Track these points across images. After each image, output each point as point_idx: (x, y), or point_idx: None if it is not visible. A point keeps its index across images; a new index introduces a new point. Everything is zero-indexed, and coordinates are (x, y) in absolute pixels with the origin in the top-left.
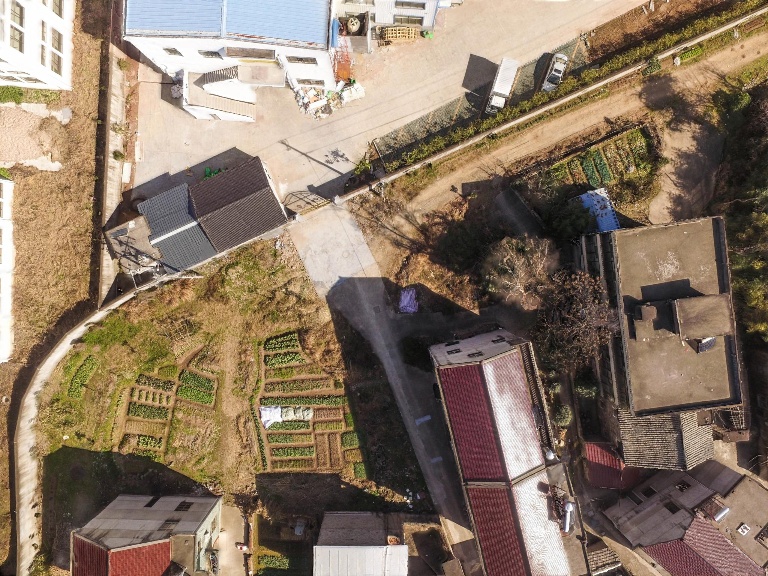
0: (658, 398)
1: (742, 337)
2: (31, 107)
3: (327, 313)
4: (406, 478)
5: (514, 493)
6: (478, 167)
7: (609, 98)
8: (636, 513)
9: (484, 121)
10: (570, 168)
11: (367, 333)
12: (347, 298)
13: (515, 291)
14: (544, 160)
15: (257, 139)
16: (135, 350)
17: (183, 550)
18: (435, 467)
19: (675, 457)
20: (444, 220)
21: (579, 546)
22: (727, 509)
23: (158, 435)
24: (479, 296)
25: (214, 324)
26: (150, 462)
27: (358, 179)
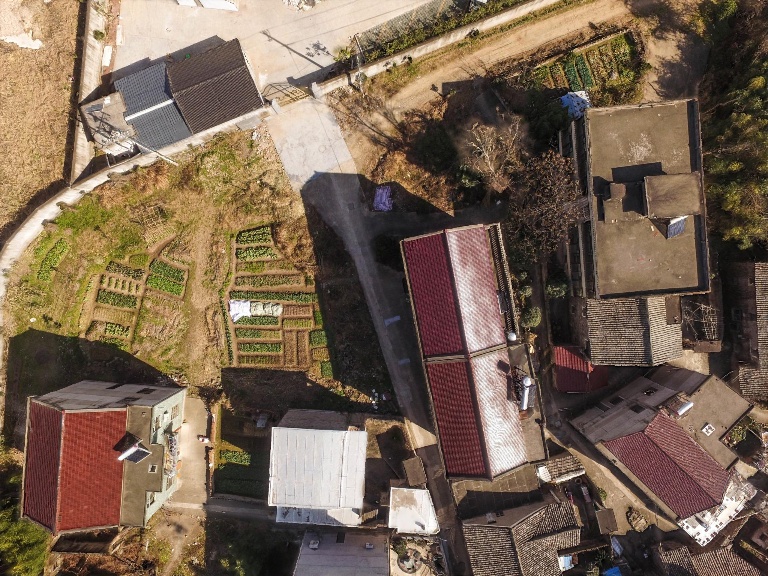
0: (625, 283)
1: (719, 251)
2: None
3: (301, 207)
4: (373, 379)
5: (473, 366)
6: (459, 67)
7: (594, 3)
8: (602, 418)
9: (466, 14)
10: (552, 72)
11: (340, 230)
12: (322, 193)
13: None
14: (525, 59)
15: (239, 28)
16: (107, 235)
17: (140, 422)
18: (402, 369)
19: (642, 353)
20: (423, 119)
21: (538, 430)
22: (691, 403)
23: (126, 323)
24: (454, 197)
25: (187, 214)
26: (116, 350)
27: (338, 73)
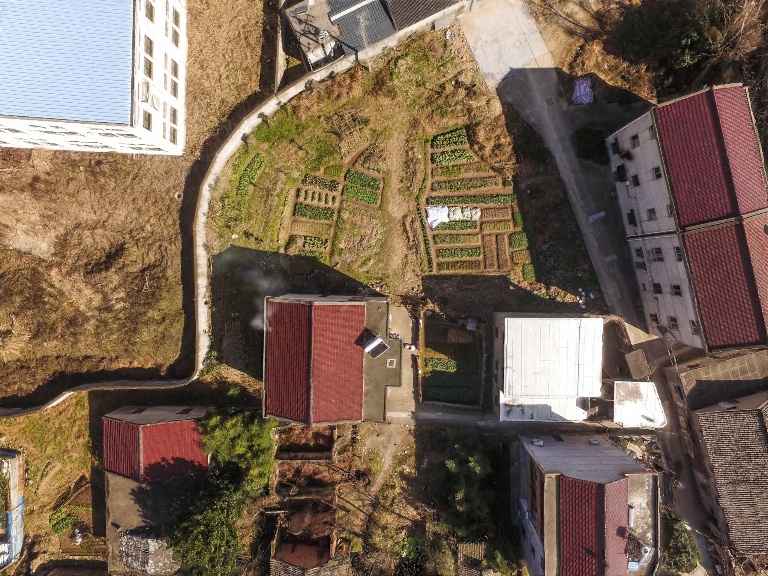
0: None
1: None
2: None
3: (498, 105)
4: (578, 278)
5: (744, 228)
6: None
7: None
8: None
9: None
10: None
11: (539, 126)
12: (518, 90)
13: (753, 5)
14: None
15: None
16: (303, 147)
17: (376, 317)
18: (609, 266)
19: None
20: (621, 5)
21: None
22: None
23: (324, 236)
24: (659, 83)
25: (381, 121)
26: (317, 263)
27: None
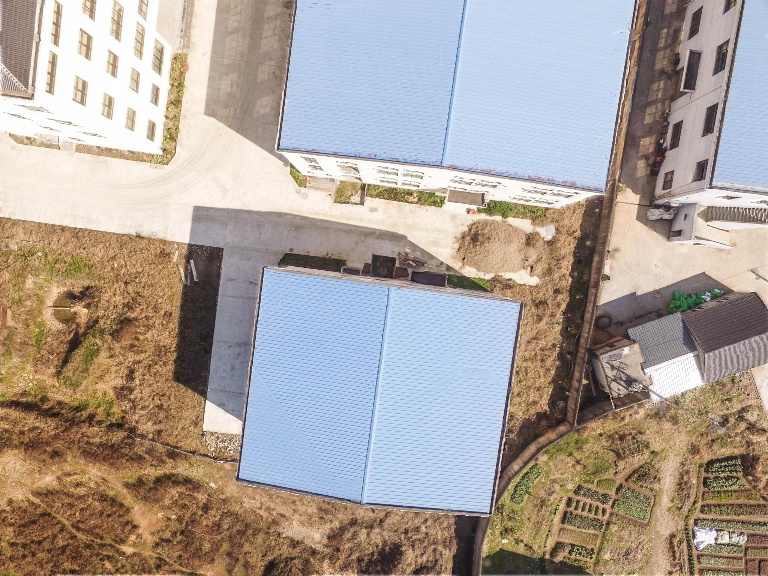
0: None
1: None
2: (517, 222)
3: None
4: None
5: None
6: None
7: None
8: None
9: None
10: None
11: None
12: None
13: None
14: None
15: (727, 266)
16: (581, 462)
17: None
18: None
19: None
20: None
21: None
22: None
23: (590, 546)
24: None
25: (659, 443)
26: (582, 572)
27: None
